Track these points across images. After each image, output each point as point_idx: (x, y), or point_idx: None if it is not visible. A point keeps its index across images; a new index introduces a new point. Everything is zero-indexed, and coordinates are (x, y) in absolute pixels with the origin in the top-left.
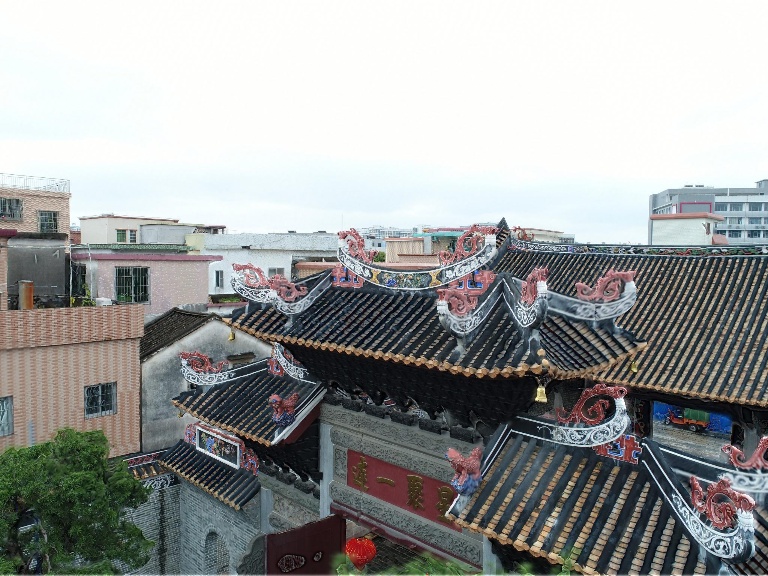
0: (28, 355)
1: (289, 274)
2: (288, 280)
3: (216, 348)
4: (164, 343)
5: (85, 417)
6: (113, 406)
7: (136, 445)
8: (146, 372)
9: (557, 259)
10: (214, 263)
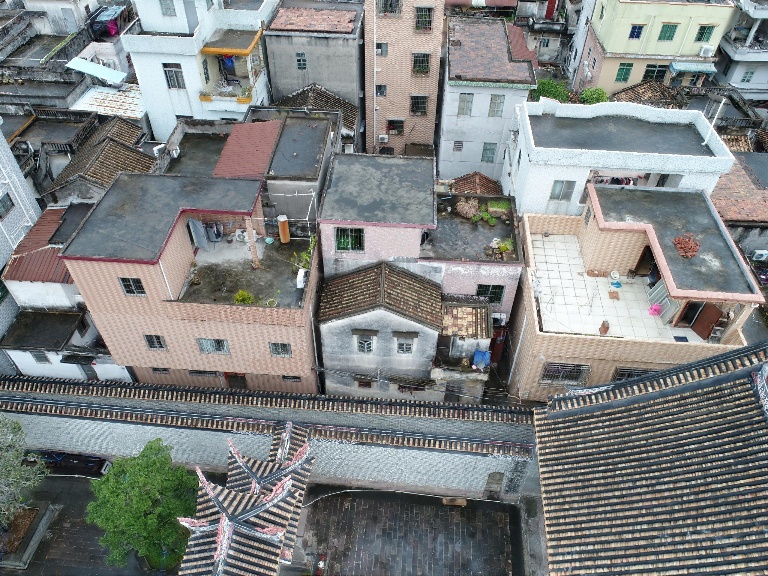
0: (232, 324)
1: (582, 187)
2: (578, 193)
3: (383, 325)
4: (338, 316)
5: (272, 355)
6: (289, 354)
7: (307, 374)
8: (323, 330)
9: (764, 454)
10: (521, 139)
